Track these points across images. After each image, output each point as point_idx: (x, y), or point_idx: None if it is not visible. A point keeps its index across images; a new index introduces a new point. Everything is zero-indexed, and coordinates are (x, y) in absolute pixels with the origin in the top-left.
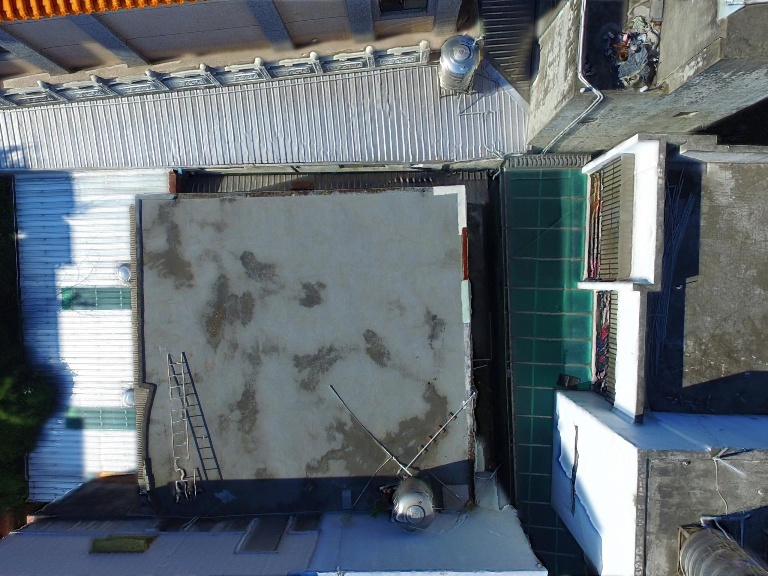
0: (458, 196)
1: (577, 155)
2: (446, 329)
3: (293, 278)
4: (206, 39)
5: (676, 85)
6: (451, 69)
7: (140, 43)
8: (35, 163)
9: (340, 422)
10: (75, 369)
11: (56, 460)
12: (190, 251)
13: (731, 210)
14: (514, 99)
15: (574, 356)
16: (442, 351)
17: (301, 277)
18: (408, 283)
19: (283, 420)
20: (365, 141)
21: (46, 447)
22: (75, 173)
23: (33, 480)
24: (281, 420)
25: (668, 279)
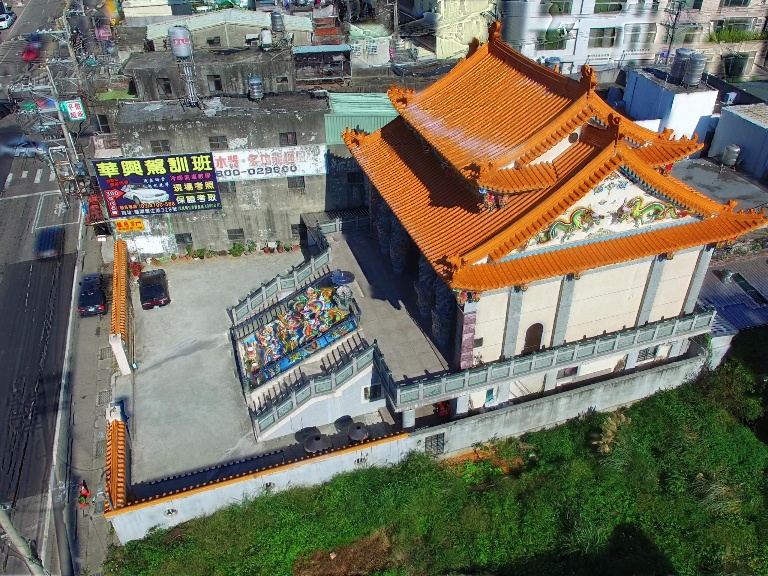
0: None
1: None
2: None
3: None
4: None
5: None
6: None
7: None
8: None
9: None
10: None
11: None
12: None
13: None
14: None
15: None
16: None
17: None
18: None
19: None
20: None
21: None
22: None
23: None
24: None
25: None
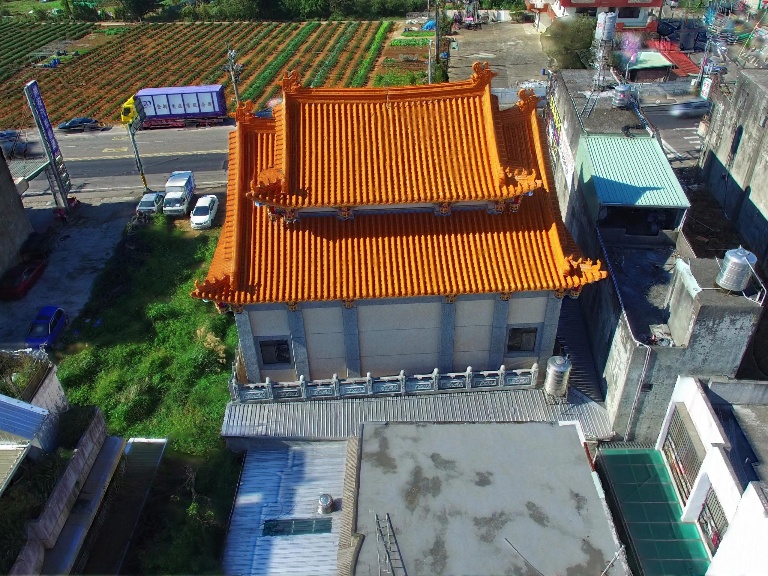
0: (576, 426)
1: (649, 443)
2: (588, 502)
3: (469, 469)
4: (403, 363)
5: (688, 339)
6: (556, 369)
7: (365, 362)
8: (273, 433)
9: (517, 567)
10: None
11: None
12: (395, 452)
13: (761, 428)
14: (596, 407)
15: (699, 573)
16: (589, 517)
17: (475, 468)
18: (553, 473)
19: (469, 564)
20: None
21: None
22: (294, 446)
23: None
24: (467, 564)
25: (738, 462)
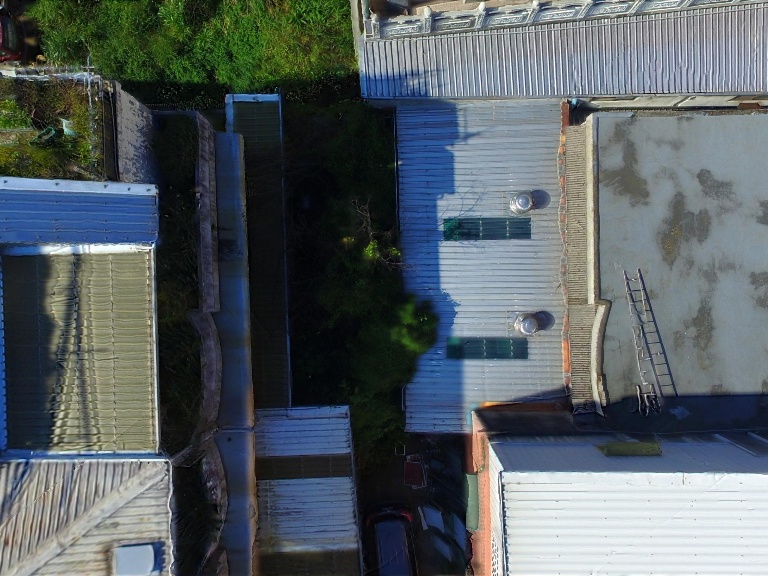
0: None
1: None
2: None
3: (750, 196)
4: None
5: None
6: None
7: None
8: (436, 91)
9: None
10: (457, 299)
11: (435, 390)
12: (646, 169)
13: None
14: None
15: None
16: None
17: (758, 195)
18: None
19: (739, 337)
20: (767, 71)
21: (424, 377)
22: (463, 104)
23: (410, 410)
24: (737, 337)
25: None
